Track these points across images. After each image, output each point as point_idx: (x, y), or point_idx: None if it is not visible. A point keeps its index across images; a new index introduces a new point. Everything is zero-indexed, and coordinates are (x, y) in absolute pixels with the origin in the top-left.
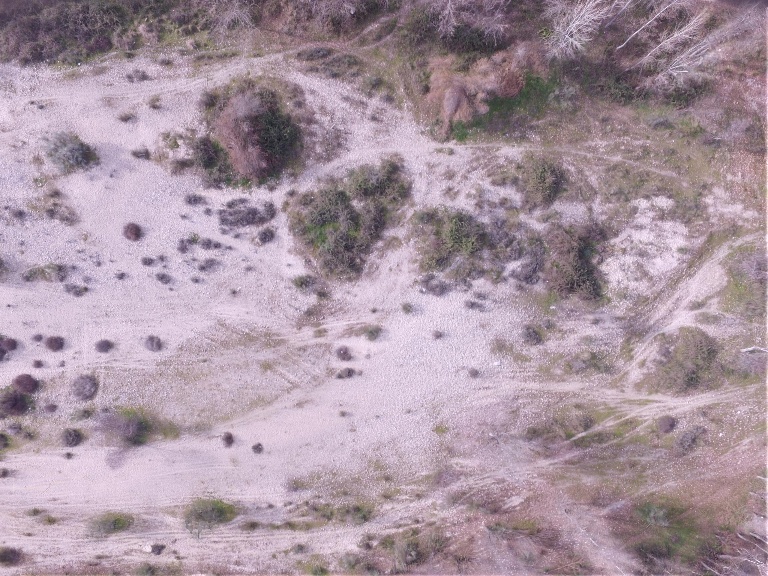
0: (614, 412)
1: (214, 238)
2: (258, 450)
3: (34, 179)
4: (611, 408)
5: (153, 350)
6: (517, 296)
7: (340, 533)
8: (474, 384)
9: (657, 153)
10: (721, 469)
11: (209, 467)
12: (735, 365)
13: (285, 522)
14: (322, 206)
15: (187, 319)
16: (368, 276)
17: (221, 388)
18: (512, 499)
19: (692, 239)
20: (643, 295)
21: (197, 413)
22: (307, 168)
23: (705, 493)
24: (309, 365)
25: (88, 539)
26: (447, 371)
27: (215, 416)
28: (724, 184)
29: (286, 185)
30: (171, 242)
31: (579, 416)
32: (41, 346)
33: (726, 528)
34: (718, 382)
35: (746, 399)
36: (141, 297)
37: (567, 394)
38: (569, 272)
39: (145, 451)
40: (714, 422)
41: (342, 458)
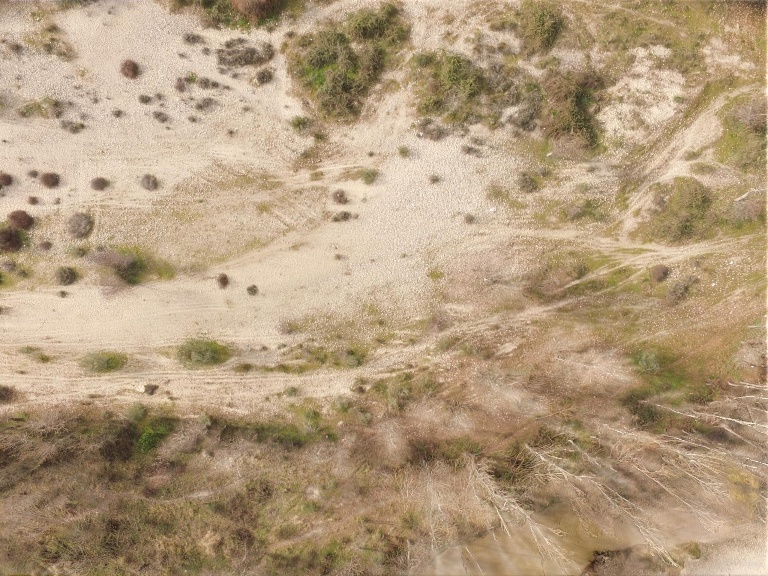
0: (608, 260)
1: (212, 78)
2: (253, 291)
3: (32, 13)
4: (605, 256)
5: (149, 189)
6: (514, 143)
7: (333, 377)
8: (469, 230)
9: (656, 3)
10: (713, 319)
11: (203, 308)
12: (729, 215)
13: (279, 364)
14: (321, 47)
15: (184, 159)
16: (366, 119)
17: (217, 229)
18: (505, 346)
19: (689, 89)
20: (639, 144)
21: (192, 254)
22: (306, 11)
23: (697, 342)
24: (305, 208)
25: (81, 378)
26: (443, 216)
27: (210, 257)
28: (722, 35)
29: (285, 27)
30: (169, 80)
31: (573, 263)
32: (36, 182)
33: (717, 377)
34: (712, 232)
35: (739, 250)
36: (138, 135)
37: (562, 242)
38: (566, 117)
39: (140, 291)
40: (707, 271)
41: (337, 301)
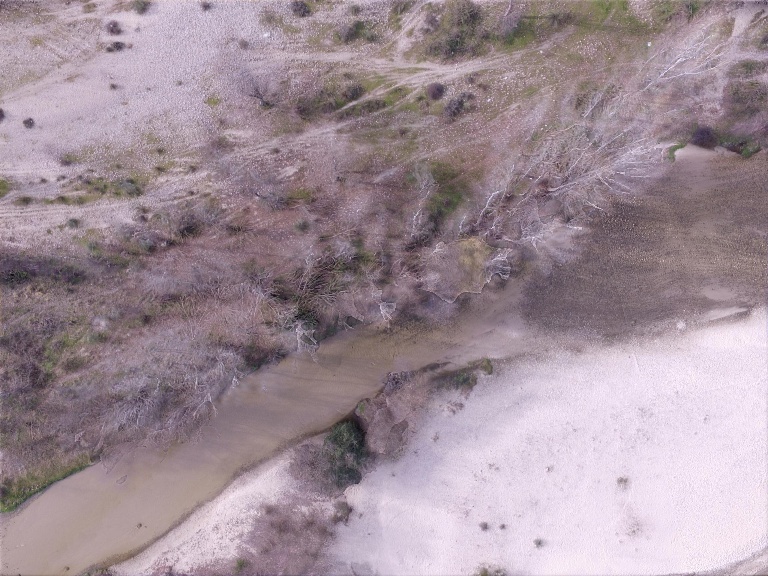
0: (384, 80)
1: None
2: (29, 124)
3: None
4: (381, 77)
5: None
6: None
7: (115, 207)
8: (245, 56)
9: None
10: (491, 134)
11: None
12: (500, 30)
13: (59, 196)
14: None
15: None
16: None
17: None
18: (286, 169)
19: None
20: None
21: None
22: None
23: (476, 158)
24: (79, 40)
25: None
26: (217, 43)
27: None
28: None
29: None
30: None
31: (349, 84)
32: None
33: (496, 190)
34: (484, 48)
35: (513, 65)
36: None
37: (337, 64)
38: None
39: None
40: (481, 87)
41: (114, 131)
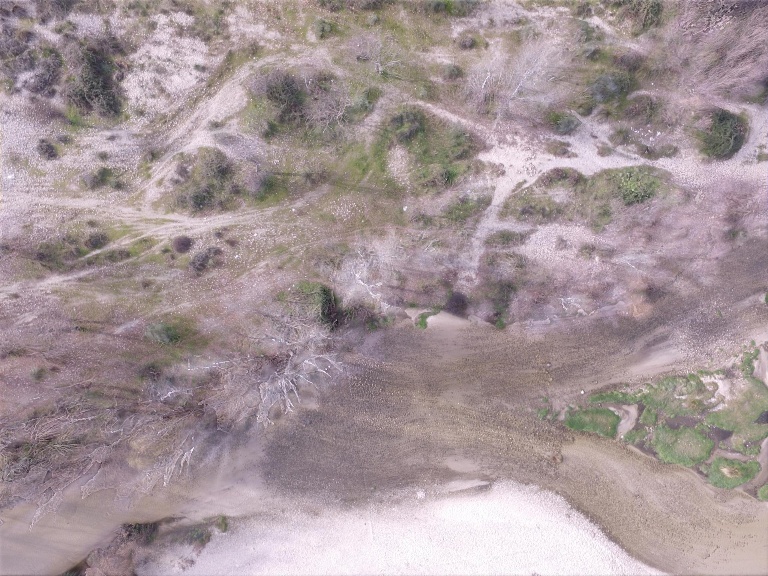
0: (130, 230)
1: None
2: None
3: None
4: (127, 226)
5: None
6: (33, 109)
7: None
8: None
9: None
10: (237, 291)
11: None
12: None
13: None
14: None
15: None
16: None
17: None
18: (25, 315)
19: (211, 57)
20: (161, 113)
21: None
22: None
23: (219, 315)
24: None
25: None
26: None
27: None
28: (247, 3)
29: None
30: None
31: (92, 232)
32: None
33: (238, 350)
34: (234, 203)
35: (263, 222)
36: None
37: (83, 211)
38: (78, 83)
39: None
40: (228, 243)
41: None
